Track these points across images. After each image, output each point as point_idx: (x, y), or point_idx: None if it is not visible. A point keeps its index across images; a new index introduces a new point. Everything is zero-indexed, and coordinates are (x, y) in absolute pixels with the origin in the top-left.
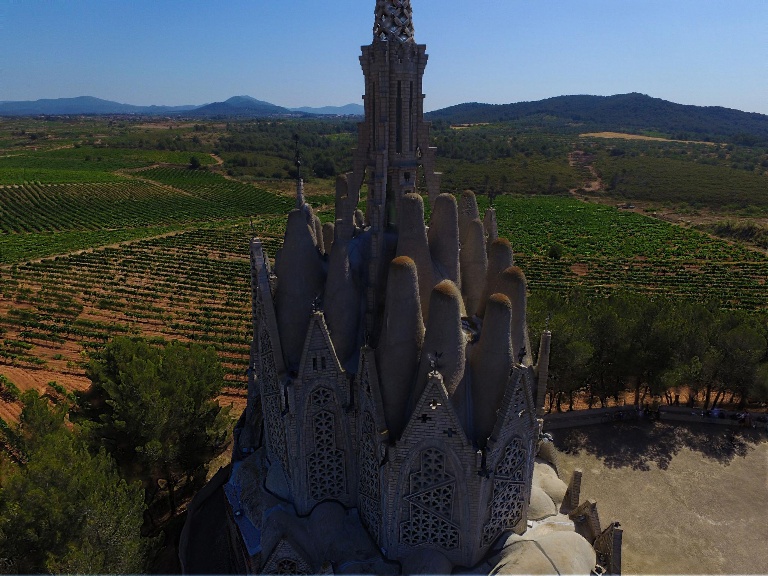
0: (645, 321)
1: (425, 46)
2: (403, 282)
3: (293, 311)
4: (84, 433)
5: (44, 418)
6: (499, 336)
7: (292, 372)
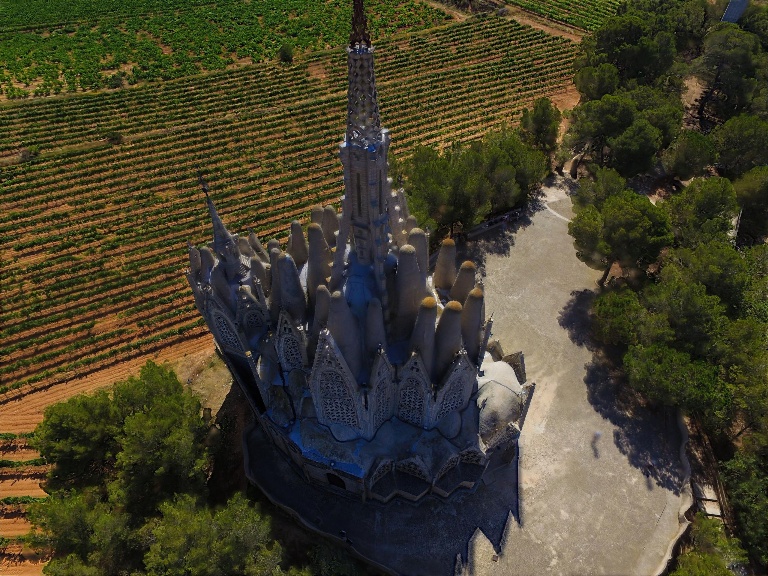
0: (457, 186)
1: None
2: (434, 314)
3: (352, 353)
4: (122, 496)
5: (68, 513)
6: (479, 311)
7: (364, 385)
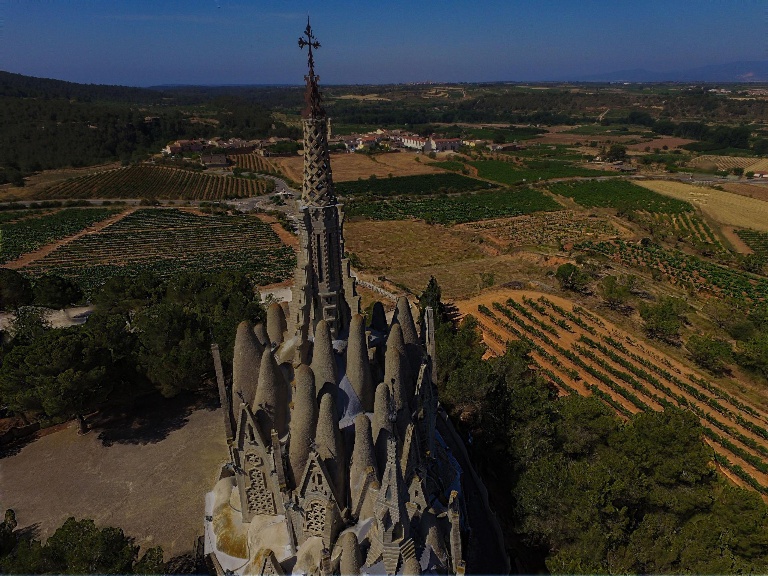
0: None
1: None
2: None
3: None
4: None
5: None
6: None
7: None
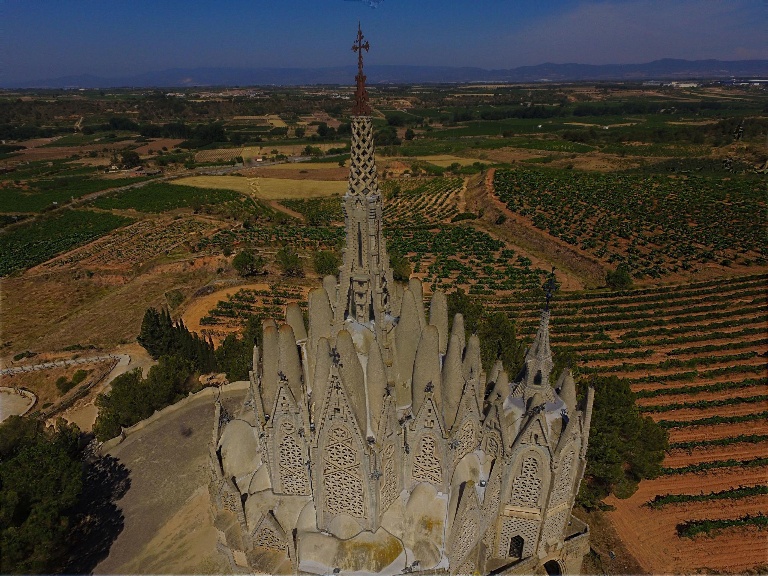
0: None
1: (343, 198)
2: None
3: None
4: None
5: None
6: None
7: None
